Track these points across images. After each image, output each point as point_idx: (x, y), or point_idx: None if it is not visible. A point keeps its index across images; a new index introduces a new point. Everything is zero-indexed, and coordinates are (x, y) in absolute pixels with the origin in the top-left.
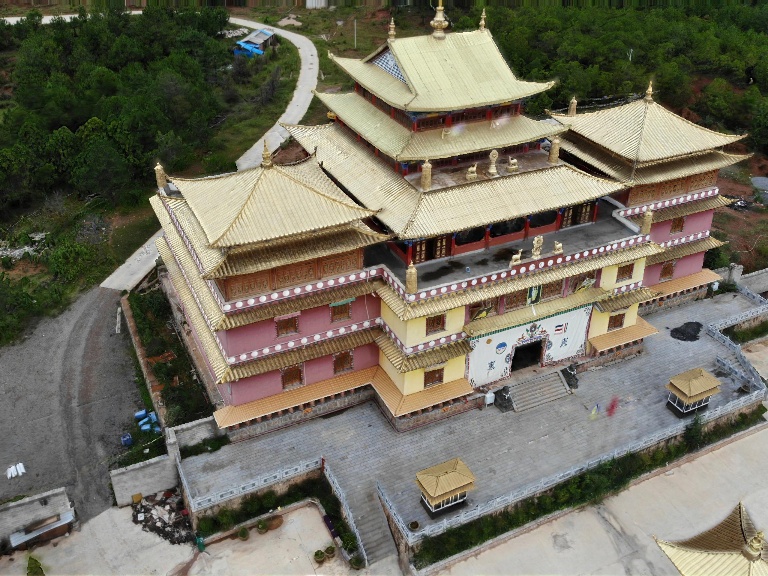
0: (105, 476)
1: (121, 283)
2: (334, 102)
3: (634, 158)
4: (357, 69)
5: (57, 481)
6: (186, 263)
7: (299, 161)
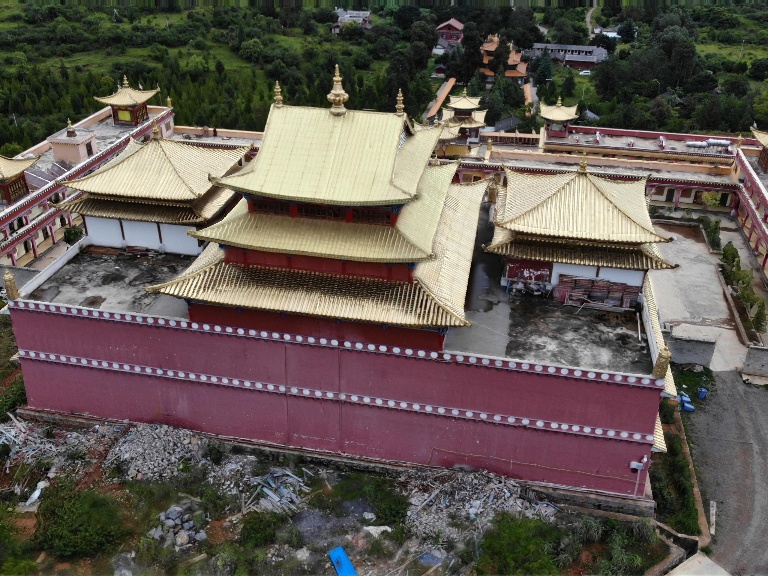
0: (720, 387)
1: (711, 573)
2: (423, 242)
3: (248, 149)
4: (407, 182)
5: (760, 396)
6: (649, 294)
7: (523, 221)
